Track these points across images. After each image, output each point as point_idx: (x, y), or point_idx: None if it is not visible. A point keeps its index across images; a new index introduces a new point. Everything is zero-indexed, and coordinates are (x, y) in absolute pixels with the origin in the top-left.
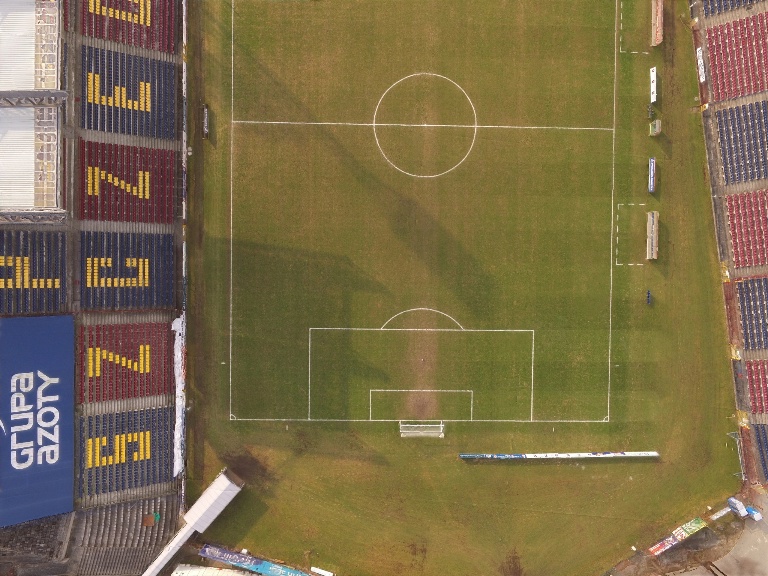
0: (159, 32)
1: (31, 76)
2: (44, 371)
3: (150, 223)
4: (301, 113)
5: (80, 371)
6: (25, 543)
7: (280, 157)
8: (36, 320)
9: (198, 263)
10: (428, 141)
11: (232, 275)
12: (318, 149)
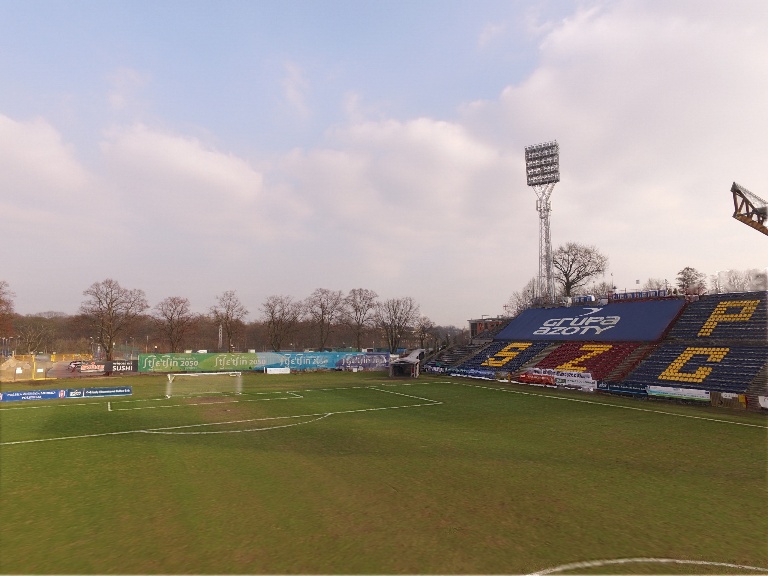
0: None
1: None
2: None
3: None
4: None
5: None
6: None
7: None
8: None
9: None
10: None
11: None
12: None
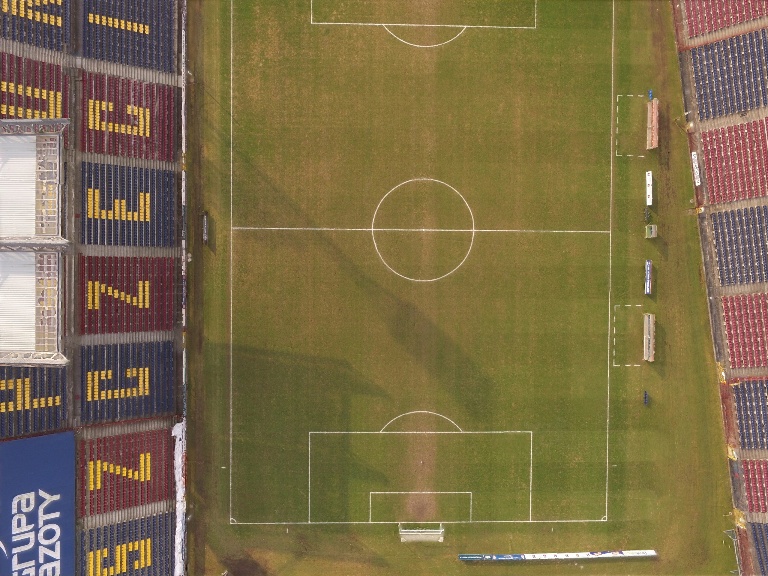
0: (158, 142)
1: (32, 221)
2: (45, 489)
3: (150, 331)
4: (300, 219)
5: (81, 485)
6: None
7: (279, 263)
8: (37, 440)
9: (198, 368)
10: (426, 245)
11: (232, 380)
12: (317, 254)
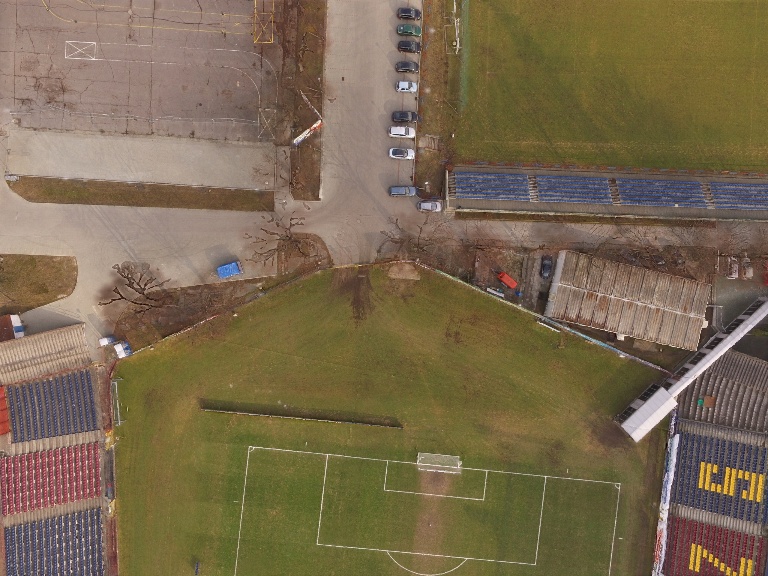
0: None
1: None
2: None
3: None
4: None
5: (760, 568)
6: None
7: None
8: None
9: None
10: None
11: None
12: None
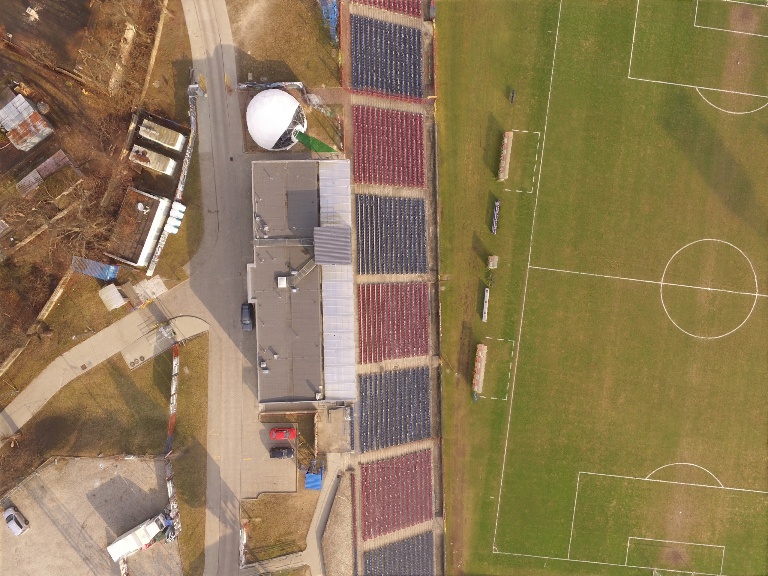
0: None
1: None
2: None
3: None
4: None
5: None
6: None
7: None
8: None
9: None
10: (709, 274)
11: None
12: None
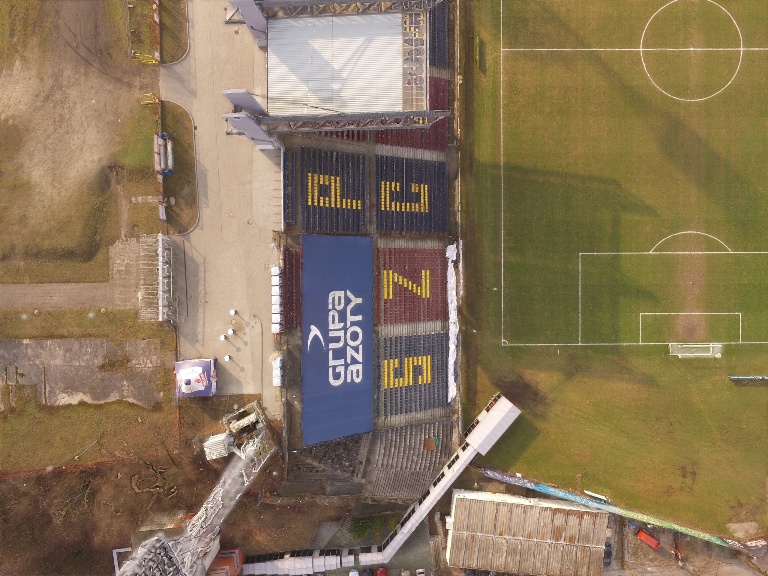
0: None
1: None
2: (351, 290)
3: (428, 150)
4: (569, 39)
5: (377, 293)
6: (334, 460)
7: (549, 84)
8: (346, 239)
9: (469, 190)
10: (695, 65)
11: (503, 202)
12: (586, 75)
